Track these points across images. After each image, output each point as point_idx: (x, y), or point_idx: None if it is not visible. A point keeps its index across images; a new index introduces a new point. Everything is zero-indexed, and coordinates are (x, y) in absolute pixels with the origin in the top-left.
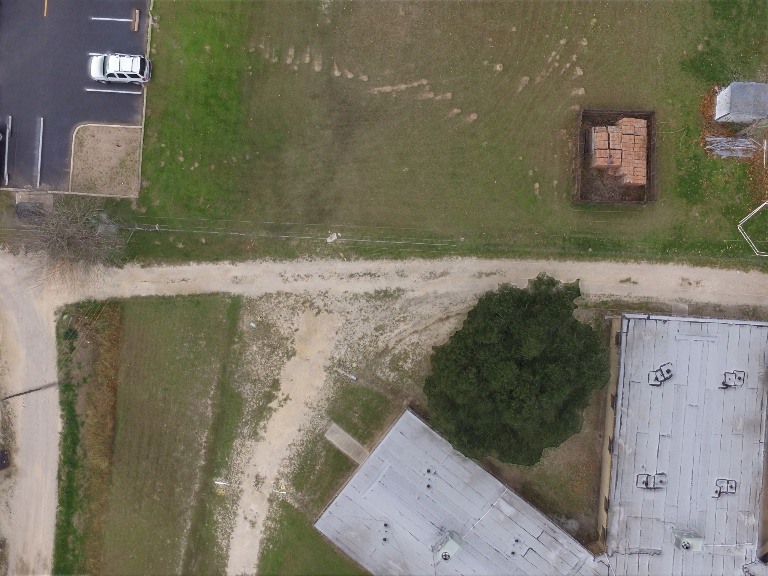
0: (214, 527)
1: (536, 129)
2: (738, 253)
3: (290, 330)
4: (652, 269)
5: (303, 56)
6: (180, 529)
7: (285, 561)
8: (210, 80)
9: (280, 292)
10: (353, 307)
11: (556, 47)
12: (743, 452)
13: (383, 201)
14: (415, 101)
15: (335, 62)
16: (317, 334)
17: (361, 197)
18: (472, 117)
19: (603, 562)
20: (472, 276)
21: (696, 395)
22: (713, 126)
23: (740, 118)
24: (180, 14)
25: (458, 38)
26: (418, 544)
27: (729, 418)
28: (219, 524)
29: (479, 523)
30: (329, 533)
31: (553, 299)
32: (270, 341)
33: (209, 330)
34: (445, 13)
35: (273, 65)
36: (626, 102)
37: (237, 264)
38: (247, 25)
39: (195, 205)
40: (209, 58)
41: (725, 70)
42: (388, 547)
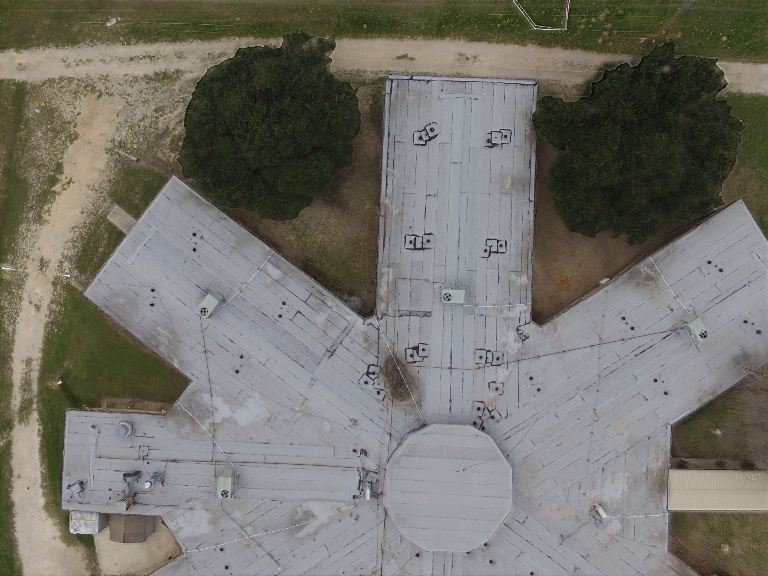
0: (1, 313)
1: None
2: (515, 27)
3: (72, 114)
4: (429, 45)
5: None
6: None
7: (70, 345)
8: None
9: (62, 77)
10: (133, 89)
11: None
12: (512, 211)
13: None
14: None
15: None
16: (99, 117)
17: None
18: None
19: (373, 325)
20: None
21: (460, 152)
22: None
23: None
24: None
25: None
26: (186, 310)
27: (497, 177)
28: (6, 310)
29: (247, 287)
30: (98, 301)
31: (305, 51)
32: (53, 125)
33: None
34: None
35: None
36: None
37: (21, 51)
38: None
39: None
40: None
41: None
42: (157, 314)
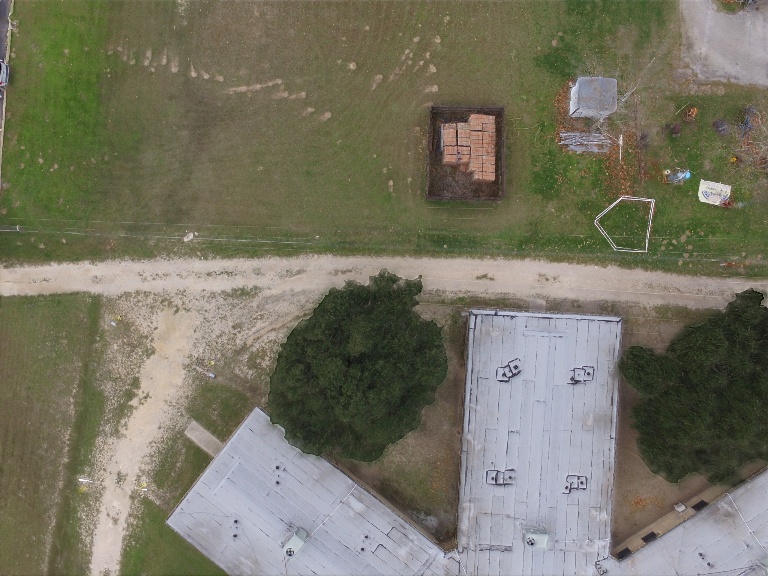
0: (78, 524)
1: (390, 127)
2: (596, 248)
3: (149, 329)
4: (509, 265)
5: (160, 58)
6: (45, 526)
7: (148, 557)
8: (69, 83)
9: (139, 291)
10: (211, 305)
11: (409, 45)
12: (593, 448)
13: (239, 200)
14: (270, 101)
15: (191, 63)
16: (176, 332)
17: (217, 196)
18: (326, 116)
19: (454, 558)
20: (328, 274)
21: (544, 391)
22: (568, 121)
23: (590, 113)
24: (39, 18)
25: (312, 38)
26: (269, 540)
27: (579, 414)
28: (83, 521)
29: (329, 519)
30: (181, 529)
31: (393, 296)
32: (130, 340)
33: (70, 329)
34: (299, 13)
35: (131, 67)
36: (480, 99)
37: (97, 264)
38: (105, 28)
39: (55, 206)
40: (68, 61)
41: (580, 65)
42: (239, 543)
